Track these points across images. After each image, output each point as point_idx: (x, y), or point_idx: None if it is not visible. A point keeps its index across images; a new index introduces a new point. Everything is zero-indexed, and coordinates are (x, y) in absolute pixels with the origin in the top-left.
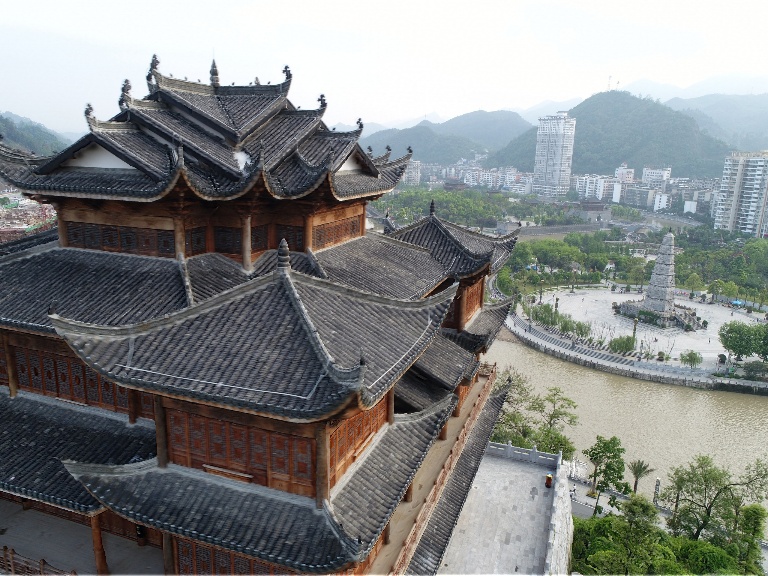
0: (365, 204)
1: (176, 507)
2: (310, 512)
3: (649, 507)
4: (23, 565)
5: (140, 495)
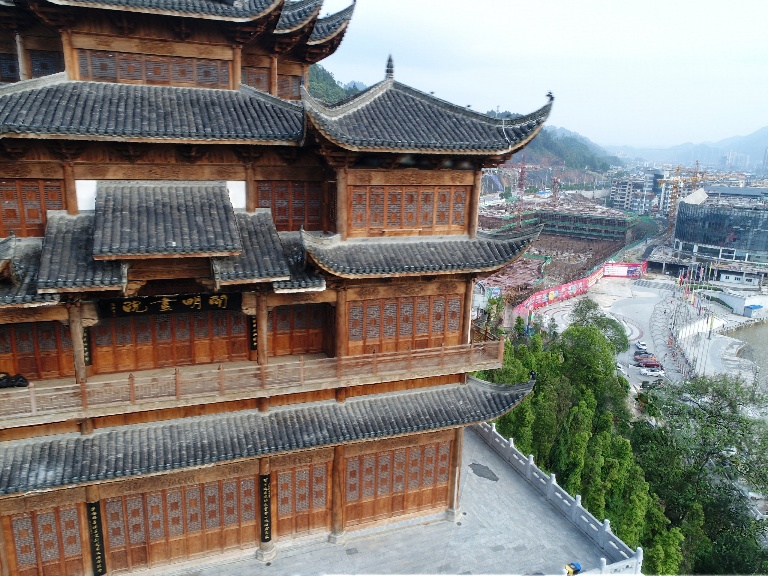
0: (233, 46)
1: None
2: None
3: None
4: None
5: None
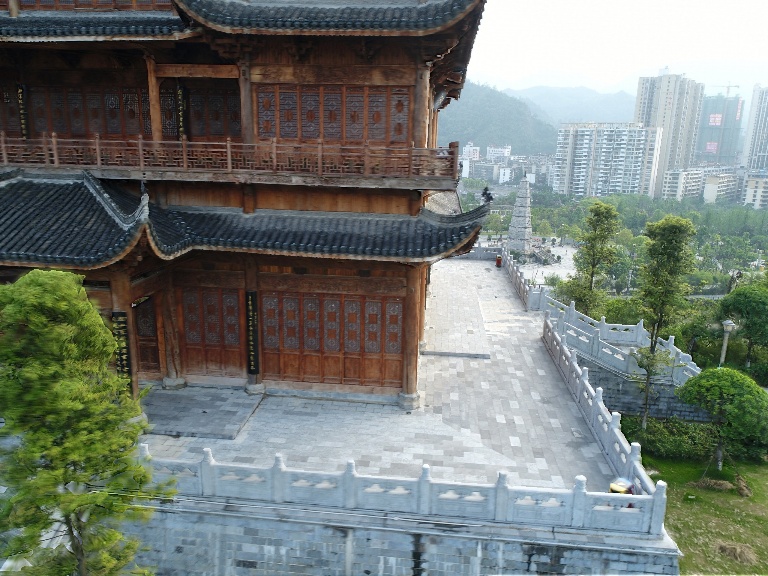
0: None
1: (274, 17)
2: (414, 7)
3: (611, 209)
4: (71, 148)
5: (230, 14)
